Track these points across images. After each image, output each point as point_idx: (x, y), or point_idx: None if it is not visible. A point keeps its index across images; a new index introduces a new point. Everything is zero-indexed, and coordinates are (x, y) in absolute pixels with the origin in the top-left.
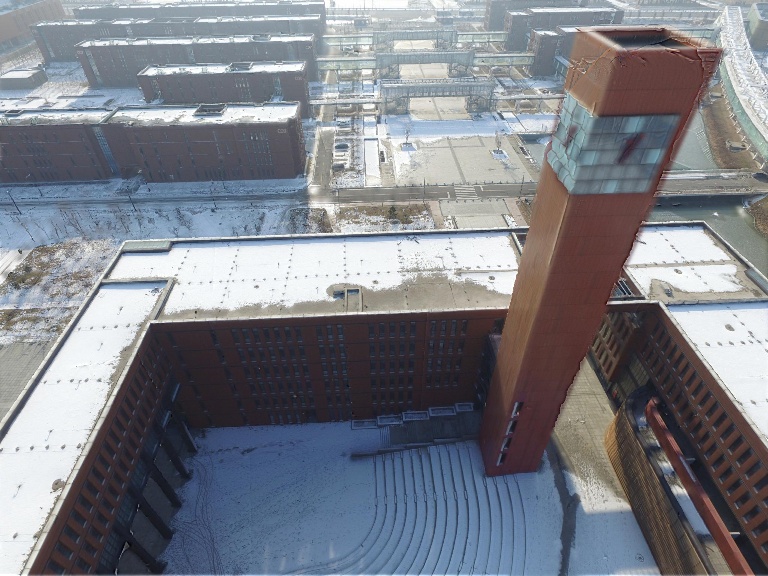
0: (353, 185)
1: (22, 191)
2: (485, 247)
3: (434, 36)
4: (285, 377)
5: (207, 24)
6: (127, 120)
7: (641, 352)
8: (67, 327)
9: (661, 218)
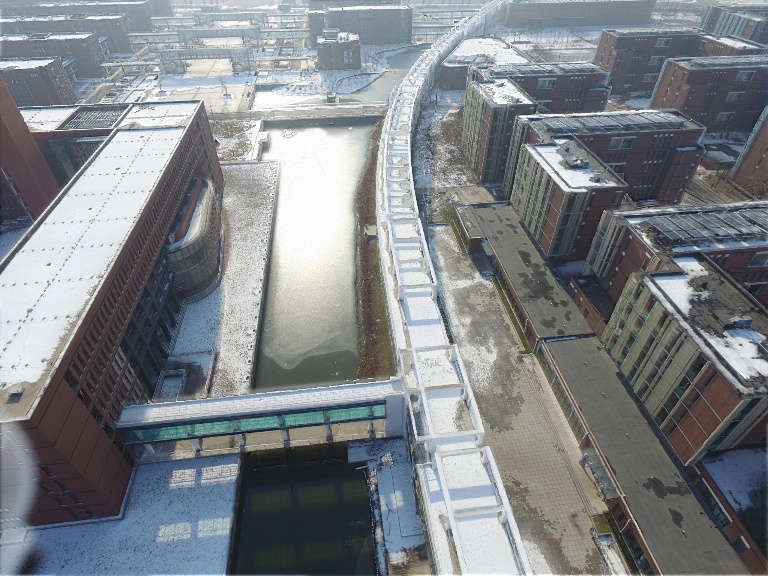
0: None
1: None
2: (56, 113)
3: (247, 17)
4: None
5: (45, 8)
6: None
7: None
8: None
9: (309, 131)
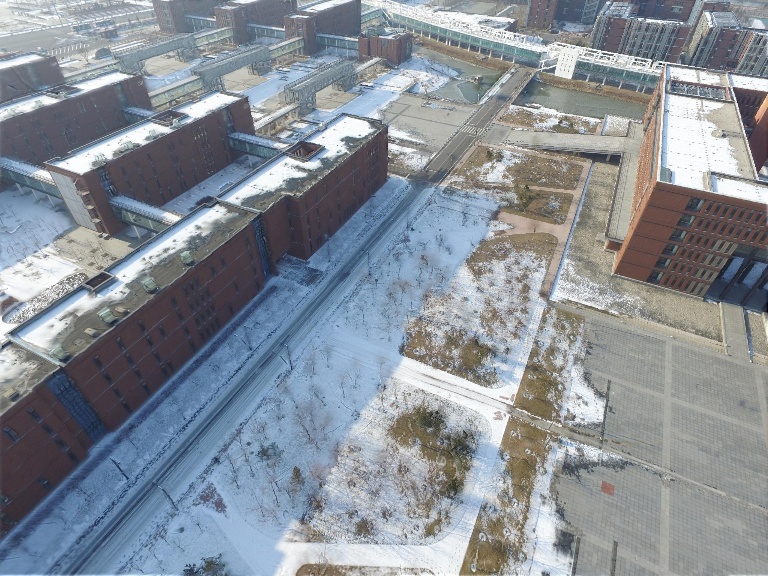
0: (424, 161)
1: (215, 369)
2: None
3: (175, 46)
4: None
5: None
6: (267, 197)
7: None
8: (767, 203)
9: (537, 100)
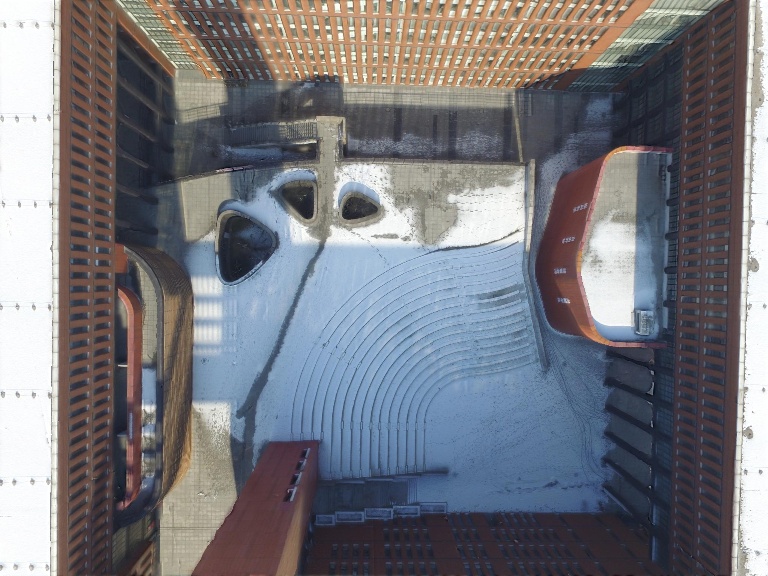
0: None
1: None
2: None
3: None
4: (535, 563)
5: None
6: None
7: (106, 572)
8: None
9: None
